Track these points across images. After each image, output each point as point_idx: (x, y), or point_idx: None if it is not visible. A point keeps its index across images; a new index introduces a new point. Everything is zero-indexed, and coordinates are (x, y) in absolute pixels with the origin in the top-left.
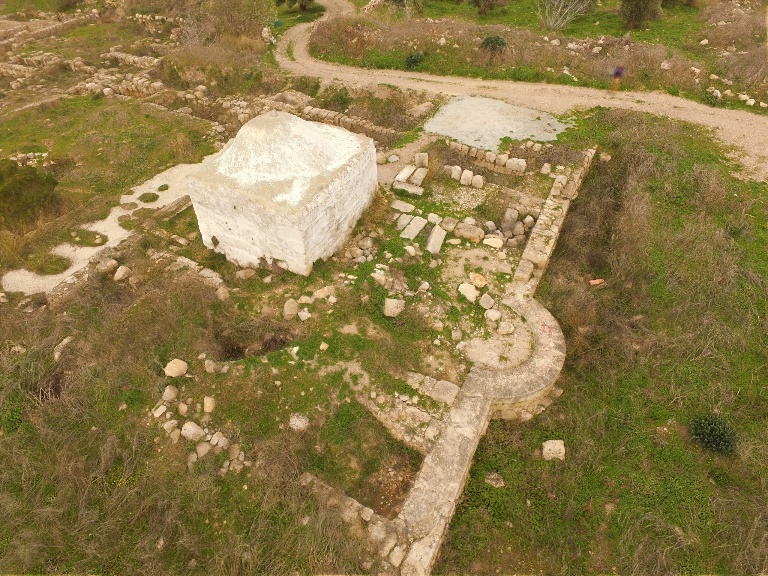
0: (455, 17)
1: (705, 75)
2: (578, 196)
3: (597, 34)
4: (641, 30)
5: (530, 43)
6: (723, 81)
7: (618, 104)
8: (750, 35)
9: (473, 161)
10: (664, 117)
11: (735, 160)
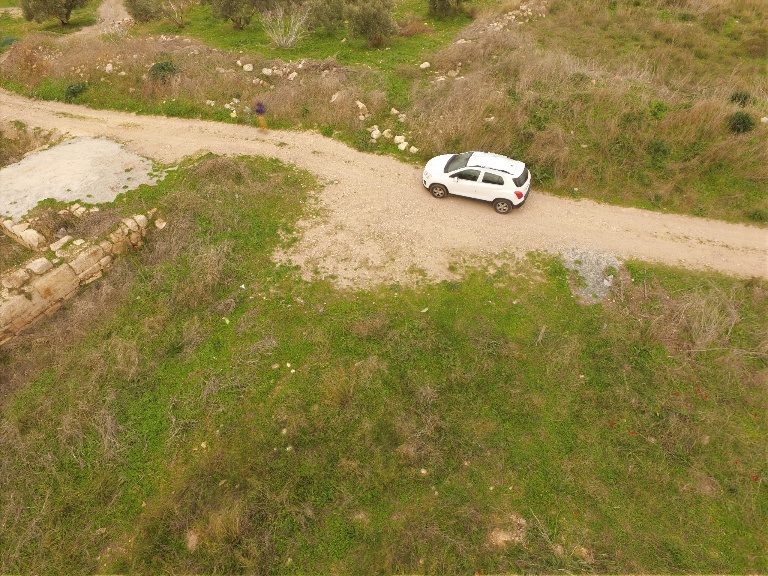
0: (210, 33)
1: (379, 109)
2: (99, 278)
3: (322, 55)
4: (380, 49)
5: (216, 69)
6: (399, 117)
7: (251, 148)
8: (486, 56)
9: (2, 230)
10: (290, 166)
11: (300, 231)
